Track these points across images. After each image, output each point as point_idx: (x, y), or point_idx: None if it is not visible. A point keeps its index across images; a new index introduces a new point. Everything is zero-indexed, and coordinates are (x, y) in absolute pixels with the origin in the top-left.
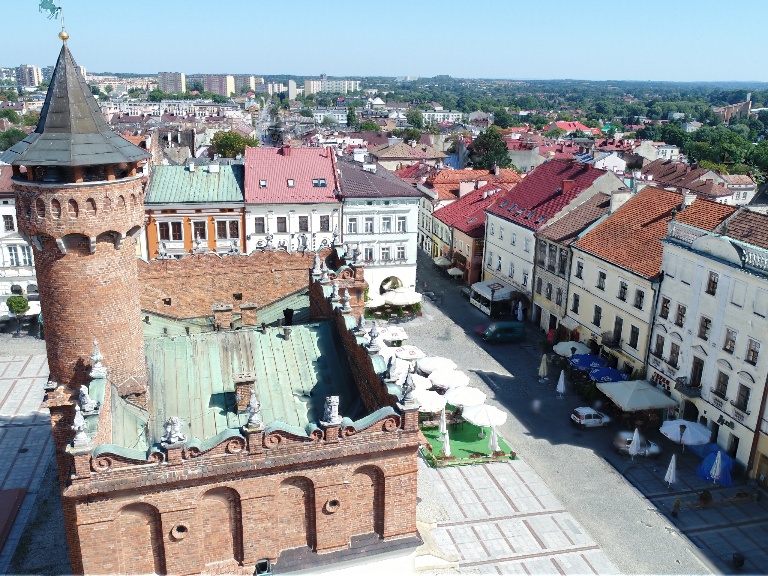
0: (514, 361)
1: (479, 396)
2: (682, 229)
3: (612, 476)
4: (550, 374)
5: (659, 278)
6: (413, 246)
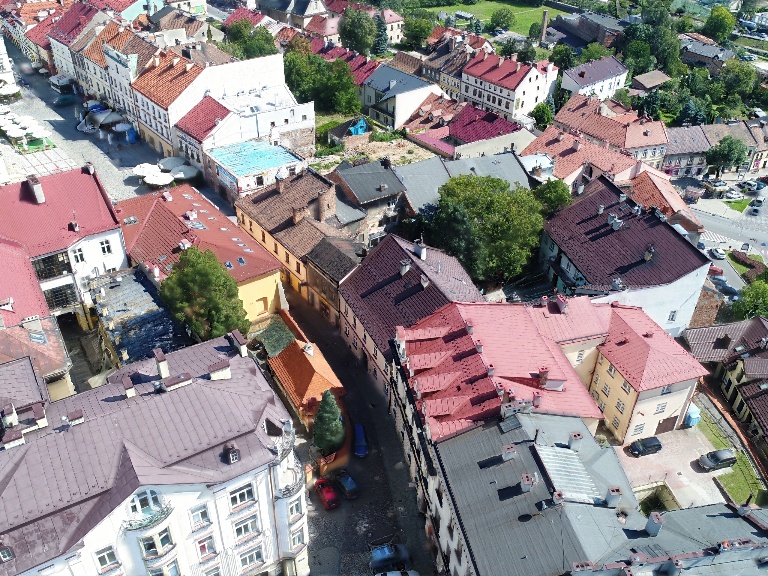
0: (67, 113)
1: (41, 128)
2: None
3: (92, 147)
4: (83, 116)
5: (106, 68)
6: (7, 61)
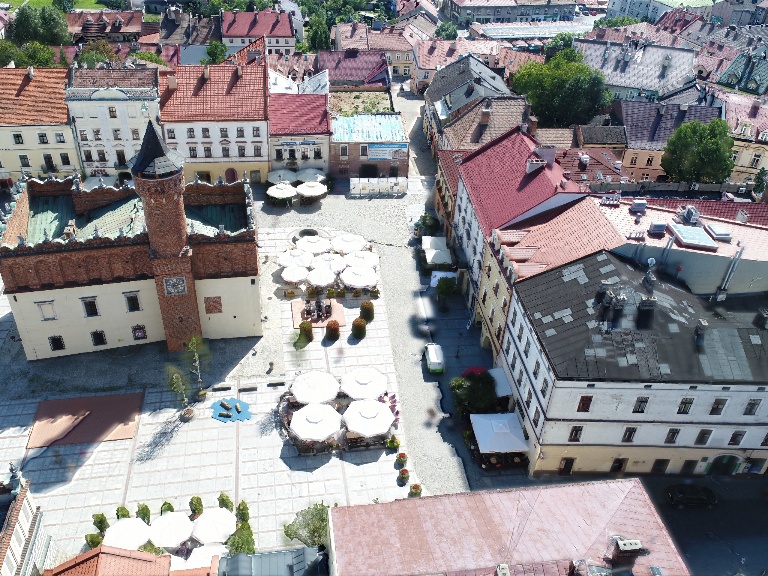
0: None
1: None
2: (77, 91)
3: None
4: None
5: (74, 121)
6: None
